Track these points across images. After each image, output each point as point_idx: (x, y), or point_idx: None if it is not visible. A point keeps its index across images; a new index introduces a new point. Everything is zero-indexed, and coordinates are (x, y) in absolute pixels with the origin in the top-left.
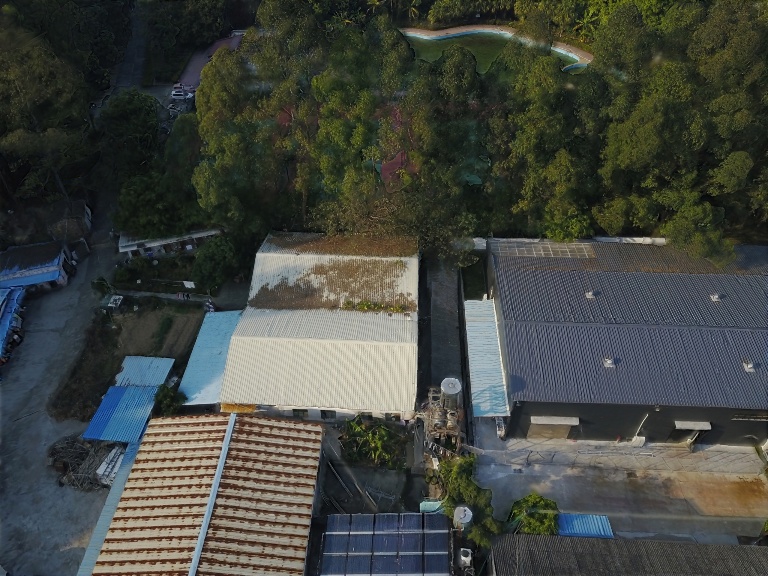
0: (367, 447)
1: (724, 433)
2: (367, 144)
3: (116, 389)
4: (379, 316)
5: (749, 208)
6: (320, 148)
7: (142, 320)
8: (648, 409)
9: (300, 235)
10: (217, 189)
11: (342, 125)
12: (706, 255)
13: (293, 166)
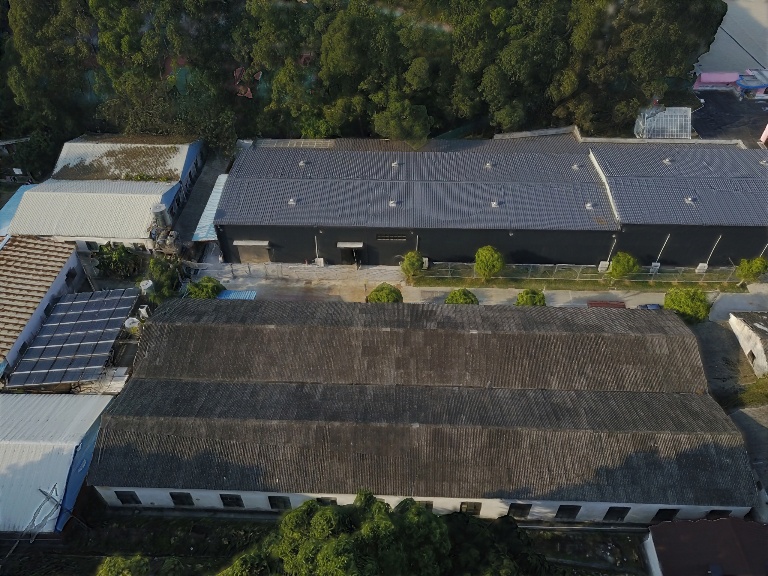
0: (108, 260)
1: (379, 254)
2: (135, 52)
3: None
4: (147, 183)
5: None
6: (105, 57)
7: None
8: (314, 231)
9: (109, 135)
10: (29, 91)
11: (113, 36)
12: (401, 138)
13: (92, 75)
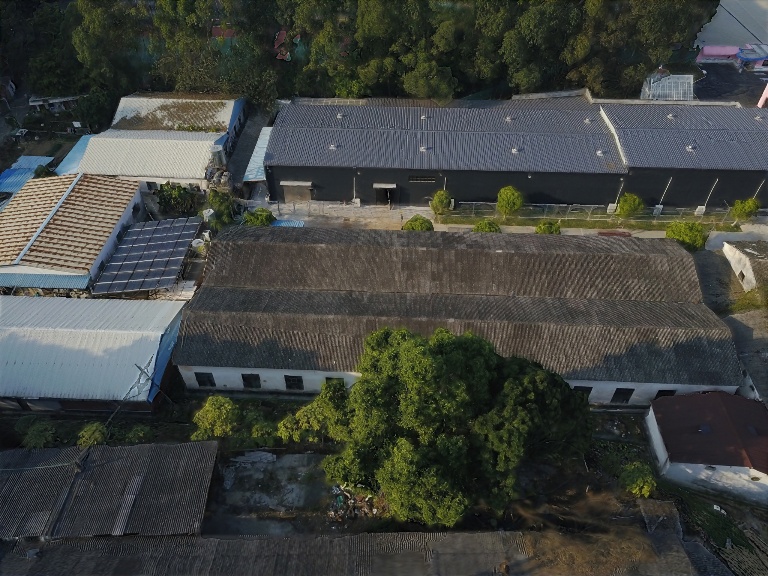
0: (169, 196)
1: (410, 195)
2: (189, 13)
3: (11, 170)
4: (198, 133)
5: (474, 71)
6: (160, 19)
7: (40, 145)
8: (353, 173)
9: (159, 93)
10: (91, 49)
11: None
12: (429, 95)
13: (147, 36)
